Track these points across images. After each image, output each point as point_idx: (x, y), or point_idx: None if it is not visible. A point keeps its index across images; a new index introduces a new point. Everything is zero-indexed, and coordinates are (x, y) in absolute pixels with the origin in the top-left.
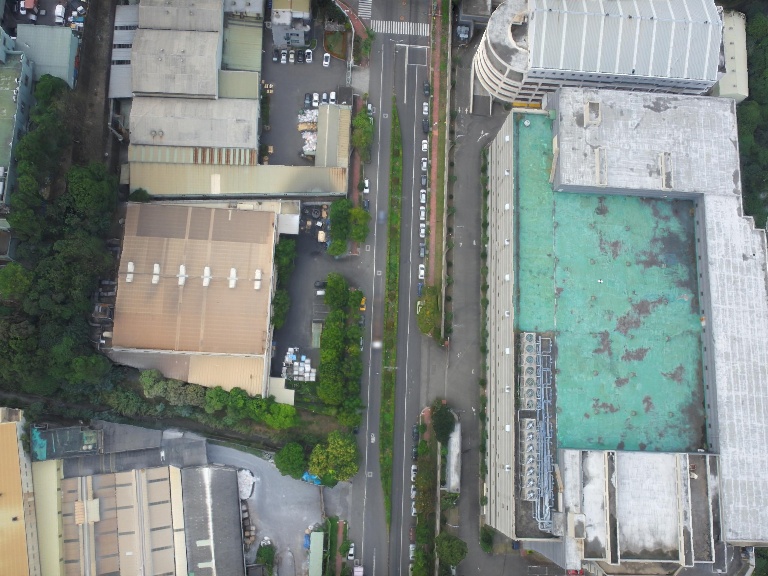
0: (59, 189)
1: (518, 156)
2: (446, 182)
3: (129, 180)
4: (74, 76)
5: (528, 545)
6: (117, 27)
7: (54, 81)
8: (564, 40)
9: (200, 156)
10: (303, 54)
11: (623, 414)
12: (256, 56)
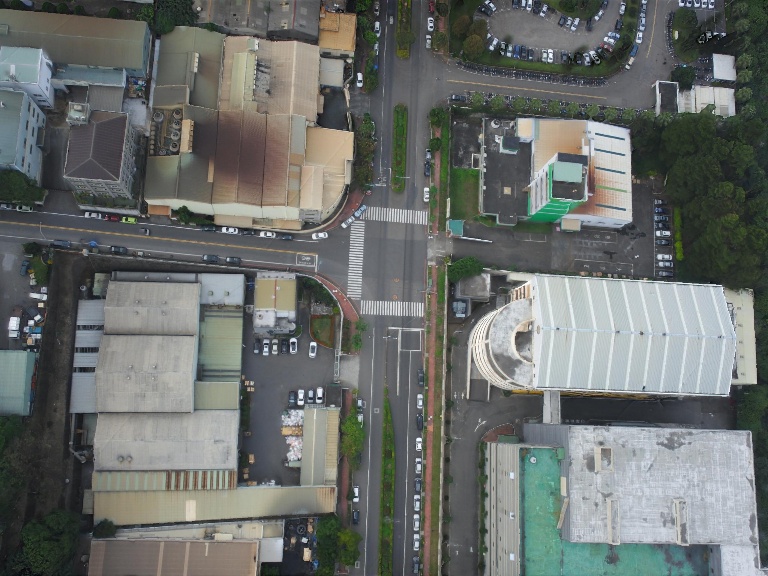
0: (13, 535)
1: (524, 498)
2: None
3: (93, 511)
4: (30, 400)
5: None
6: (79, 326)
7: (7, 429)
8: (572, 358)
9: (173, 481)
10: (287, 344)
11: None
12: (236, 352)
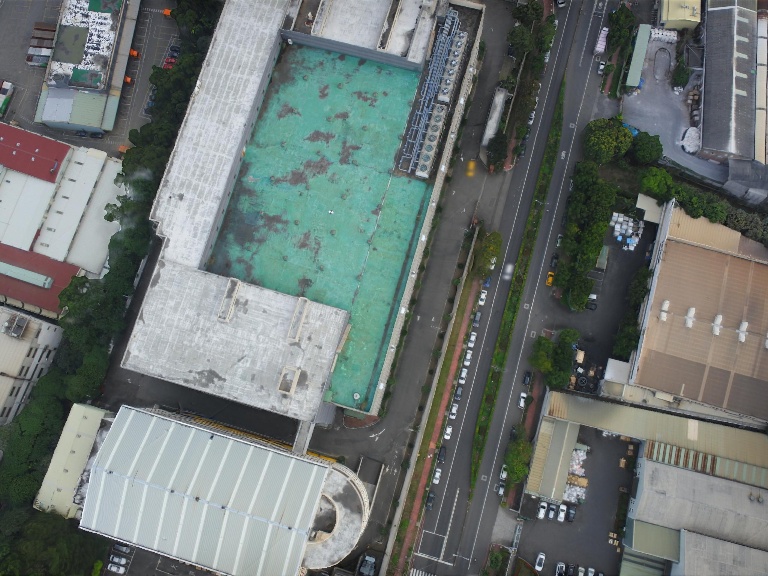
0: None
1: (376, 362)
2: (433, 388)
3: None
4: None
5: None
6: None
7: None
8: (282, 490)
9: (709, 463)
10: (567, 575)
11: (351, 88)
12: None
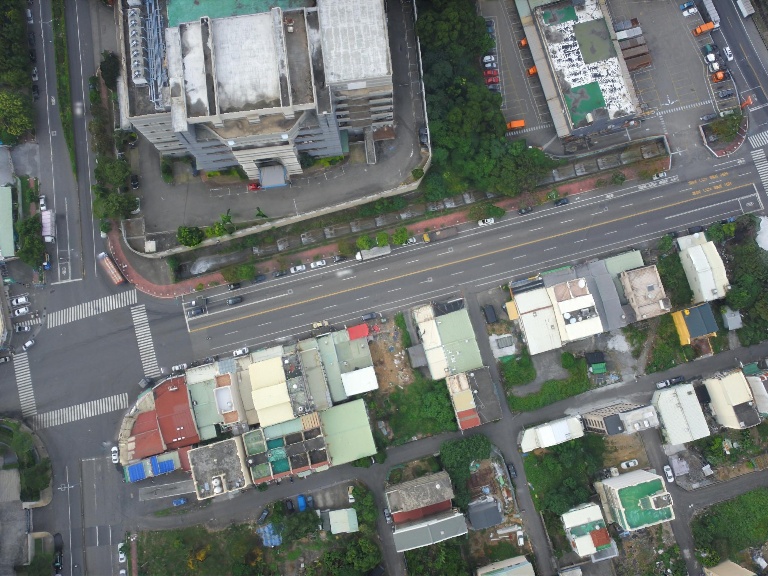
0: None
1: None
2: None
3: None
4: None
5: (200, 165)
6: None
7: None
8: None
9: None
10: None
11: None
12: None
